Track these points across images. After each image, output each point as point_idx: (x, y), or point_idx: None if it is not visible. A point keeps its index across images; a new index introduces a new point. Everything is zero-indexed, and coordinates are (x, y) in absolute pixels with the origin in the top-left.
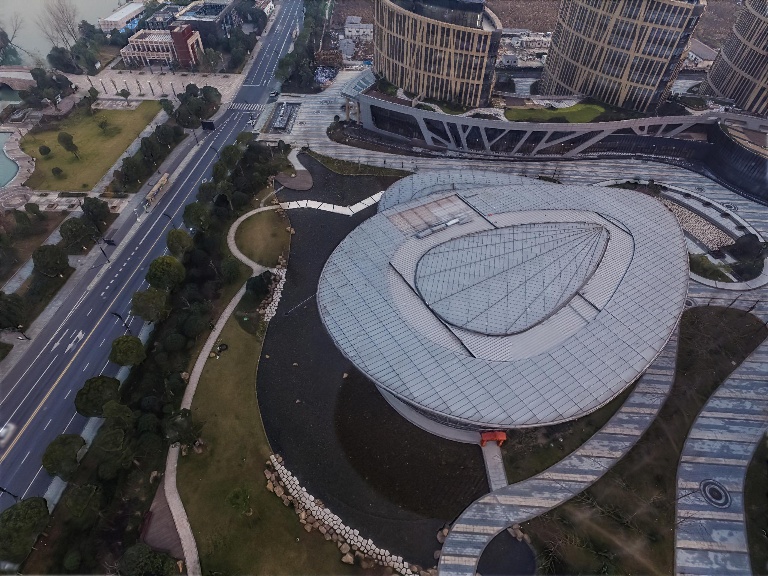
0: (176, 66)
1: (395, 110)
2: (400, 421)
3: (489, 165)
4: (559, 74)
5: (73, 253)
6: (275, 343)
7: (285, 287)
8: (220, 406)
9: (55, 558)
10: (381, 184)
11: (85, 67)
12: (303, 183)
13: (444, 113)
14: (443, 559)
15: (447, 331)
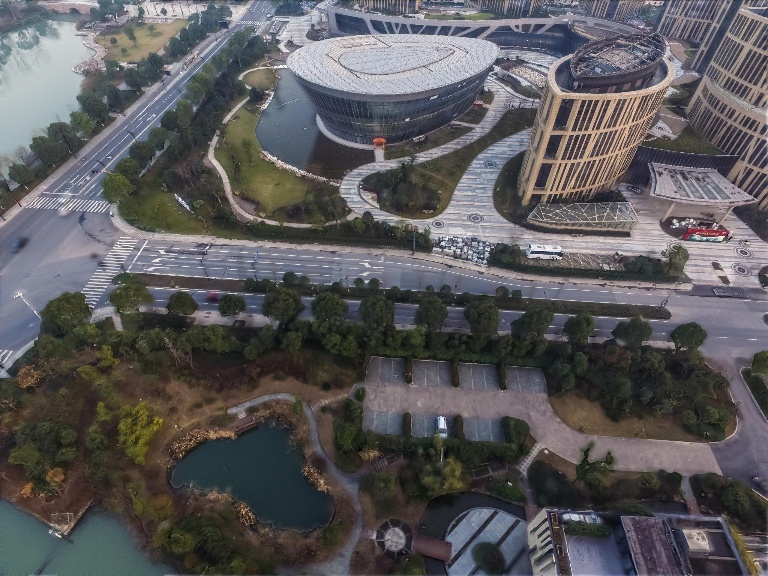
0: None
1: (351, 15)
2: (333, 143)
3: None
4: None
5: (143, 86)
6: (266, 118)
7: (273, 99)
8: (236, 135)
9: (157, 175)
10: None
11: (131, 0)
12: None
13: (383, 16)
14: (345, 178)
15: (350, 72)
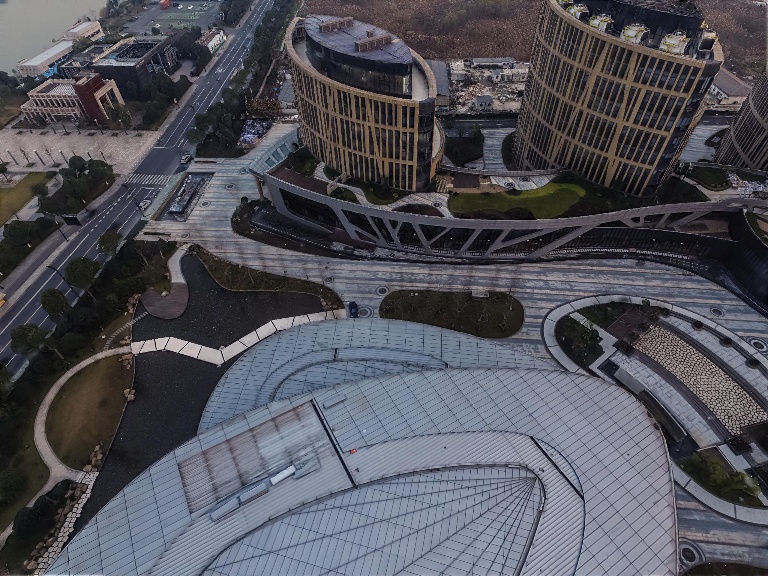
0: (83, 123)
1: (307, 197)
2: None
3: (427, 272)
4: (531, 136)
5: None
6: None
7: (86, 508)
8: None
9: None
10: (276, 306)
11: None
12: (173, 306)
13: (367, 203)
14: None
15: None
